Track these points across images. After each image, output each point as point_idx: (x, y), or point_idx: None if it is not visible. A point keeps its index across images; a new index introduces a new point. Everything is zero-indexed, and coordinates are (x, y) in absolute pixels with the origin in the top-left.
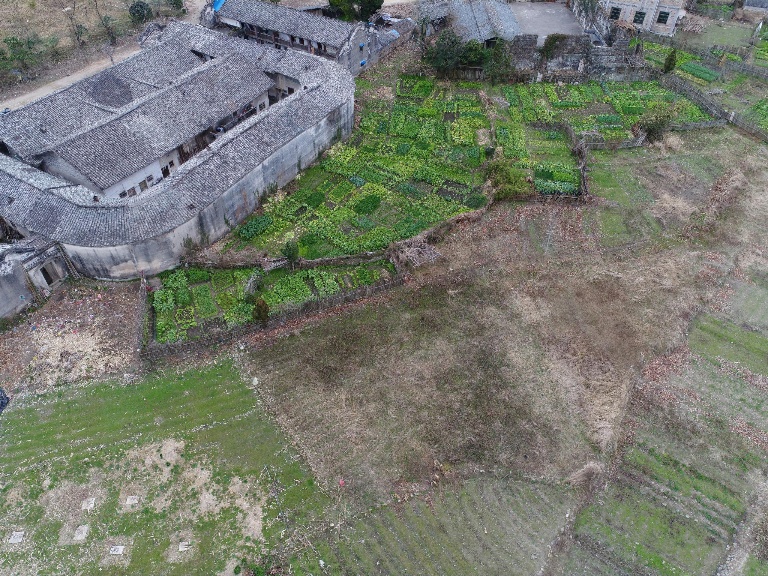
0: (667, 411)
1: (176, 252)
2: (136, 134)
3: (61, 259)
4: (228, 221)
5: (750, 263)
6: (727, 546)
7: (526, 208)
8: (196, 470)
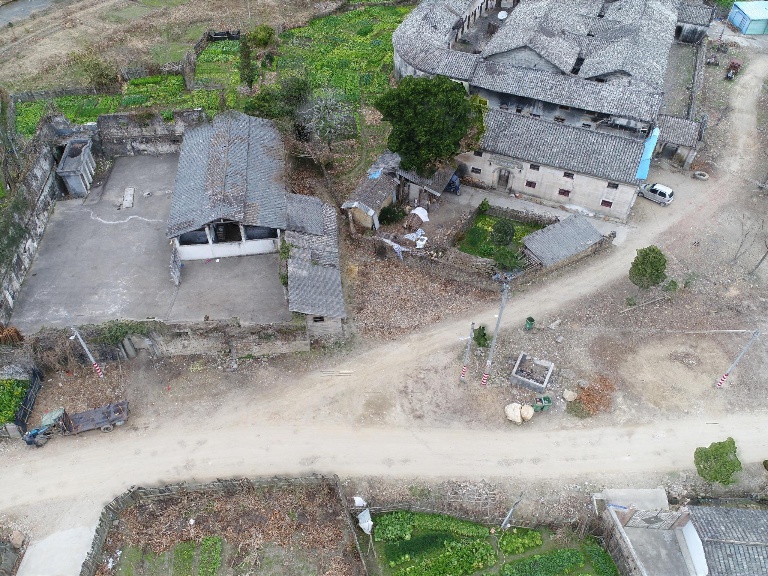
0: None
1: None
2: (540, 0)
3: None
4: None
5: None
6: None
7: None
8: None
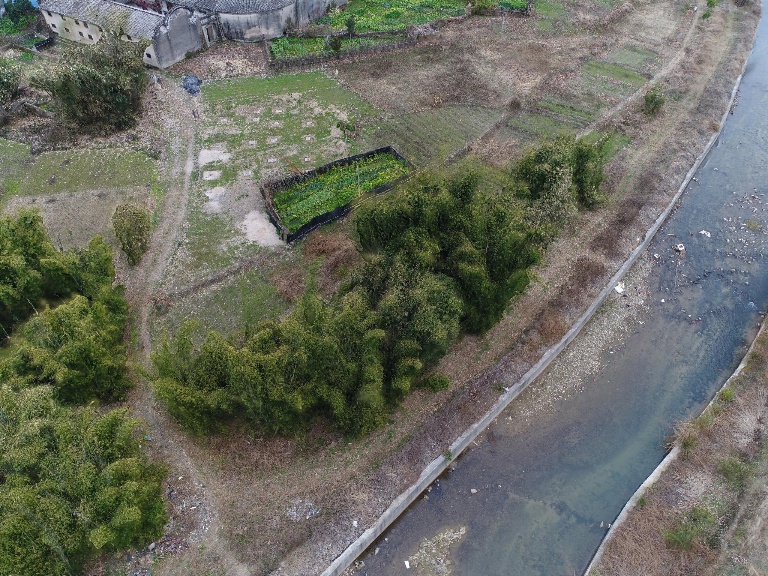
0: (562, 91)
1: (282, 25)
2: None
3: (216, 26)
4: (309, 16)
5: (625, 42)
6: (583, 129)
7: (492, 18)
8: (310, 102)
